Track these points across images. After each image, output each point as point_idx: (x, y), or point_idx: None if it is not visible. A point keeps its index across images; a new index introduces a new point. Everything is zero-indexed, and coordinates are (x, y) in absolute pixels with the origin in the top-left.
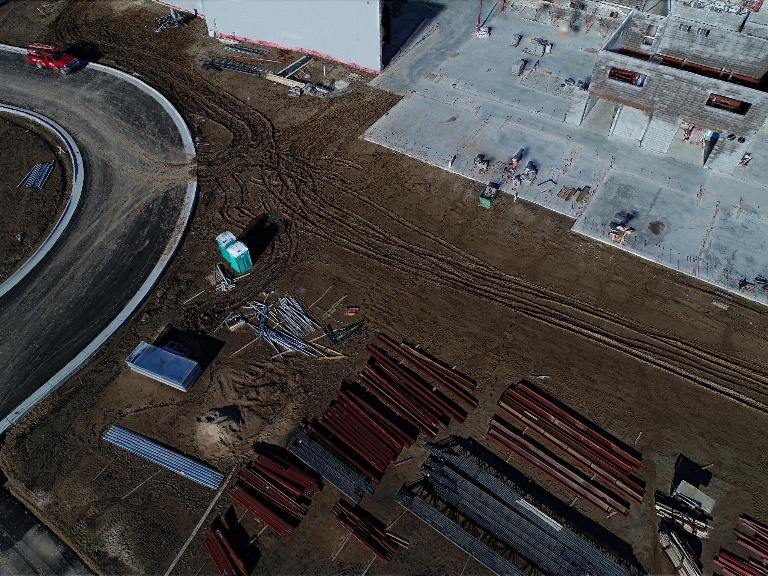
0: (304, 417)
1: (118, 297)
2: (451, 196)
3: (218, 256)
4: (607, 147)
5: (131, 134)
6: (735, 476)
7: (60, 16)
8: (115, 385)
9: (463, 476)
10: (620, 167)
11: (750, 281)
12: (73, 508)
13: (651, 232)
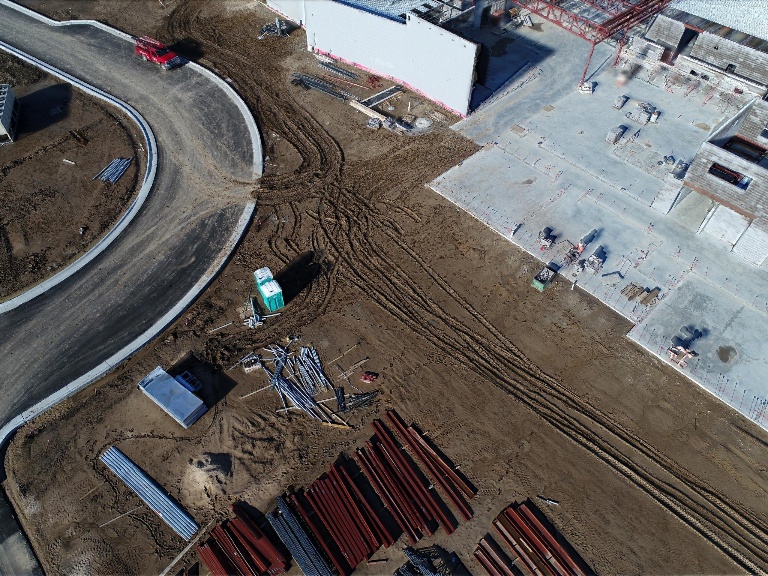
0: (291, 484)
1: (152, 312)
2: (505, 269)
3: (255, 288)
4: (692, 245)
5: (208, 142)
6: None
7: (176, 9)
8: (124, 404)
9: None
10: (701, 272)
11: None
12: (54, 524)
13: (718, 358)
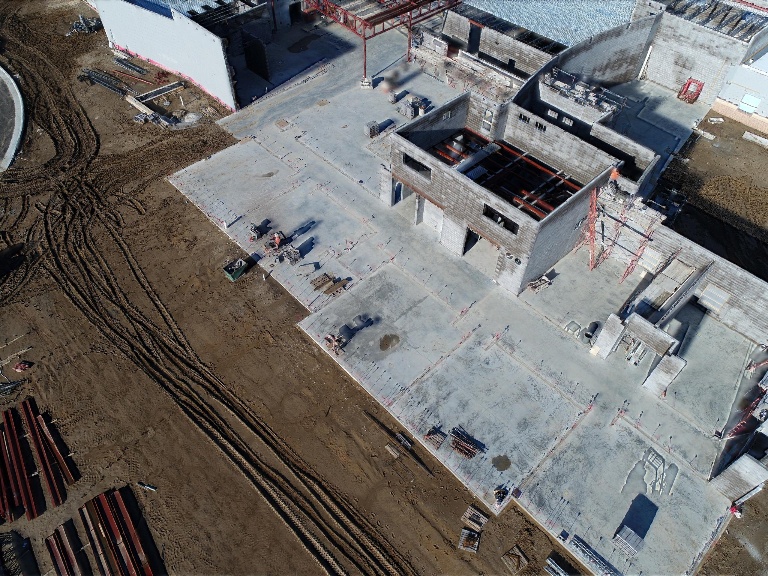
0: None
1: None
2: (207, 260)
3: None
4: (404, 236)
5: None
6: None
7: None
8: None
9: None
10: (401, 262)
11: (444, 430)
12: None
13: (378, 346)
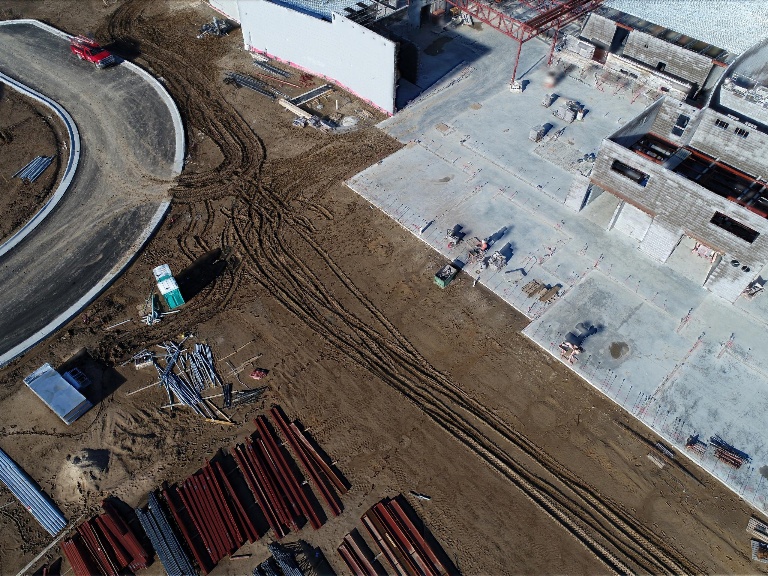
0: (166, 480)
1: (51, 309)
2: (410, 267)
3: None
4: (600, 242)
5: (132, 141)
6: None
7: (120, 8)
8: (10, 401)
9: None
10: (605, 269)
11: (702, 439)
12: None
13: (610, 354)
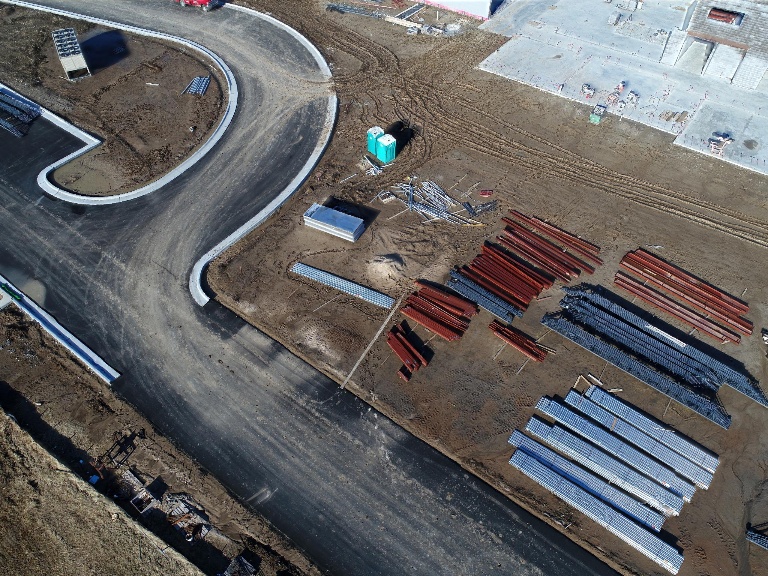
0: (456, 265)
1: (284, 175)
2: (563, 114)
3: (364, 150)
4: (701, 83)
5: (272, 58)
6: None
7: None
8: (293, 235)
9: (597, 308)
10: (714, 98)
11: None
12: (274, 315)
13: (746, 147)
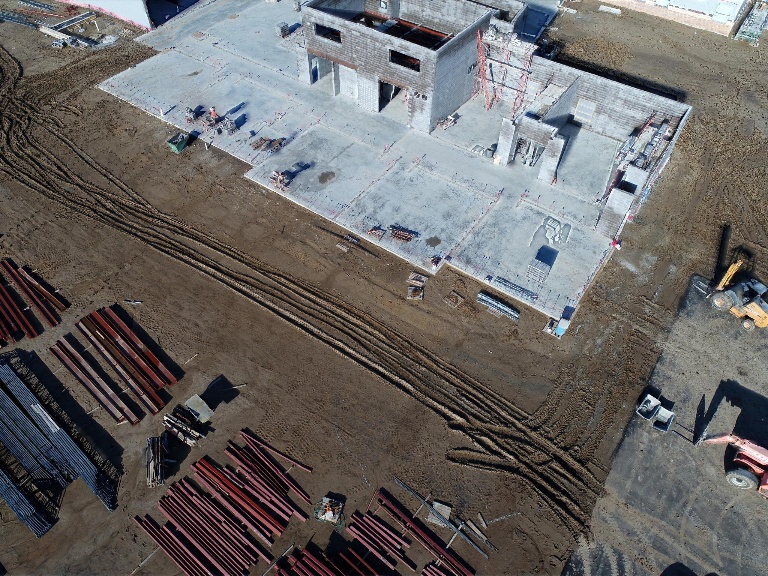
0: None
1: None
2: (150, 142)
3: None
4: (326, 104)
5: None
6: (260, 395)
7: None
8: None
9: None
10: None
11: (383, 228)
12: None
13: (318, 181)
